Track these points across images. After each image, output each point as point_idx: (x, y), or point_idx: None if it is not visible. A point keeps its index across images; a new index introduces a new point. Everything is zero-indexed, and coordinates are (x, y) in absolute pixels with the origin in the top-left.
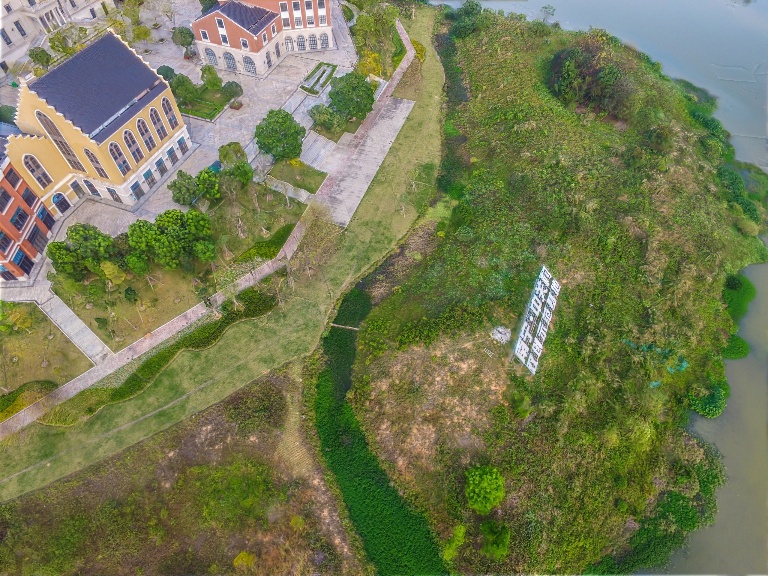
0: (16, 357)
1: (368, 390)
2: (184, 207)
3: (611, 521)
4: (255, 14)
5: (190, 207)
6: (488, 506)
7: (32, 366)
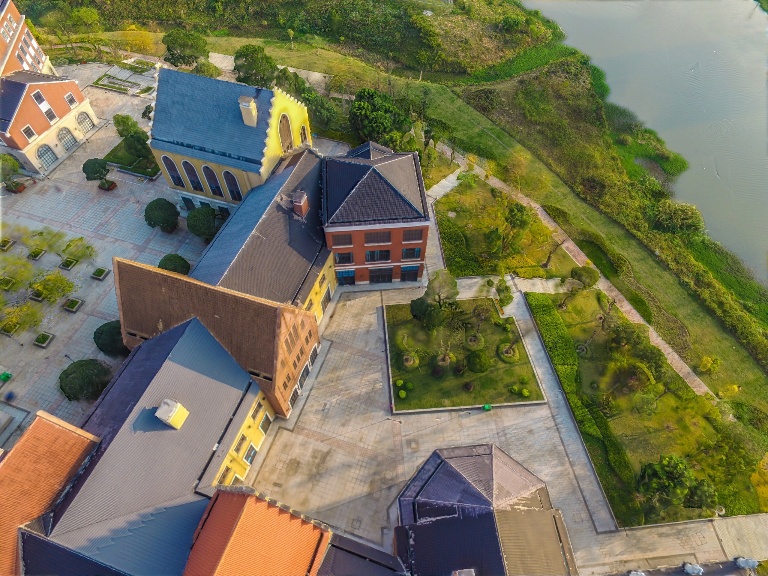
0: (480, 207)
1: (465, 62)
2: (319, 142)
3: (509, 8)
4: (29, 75)
5: (319, 138)
6: (520, 19)
7: (484, 199)
